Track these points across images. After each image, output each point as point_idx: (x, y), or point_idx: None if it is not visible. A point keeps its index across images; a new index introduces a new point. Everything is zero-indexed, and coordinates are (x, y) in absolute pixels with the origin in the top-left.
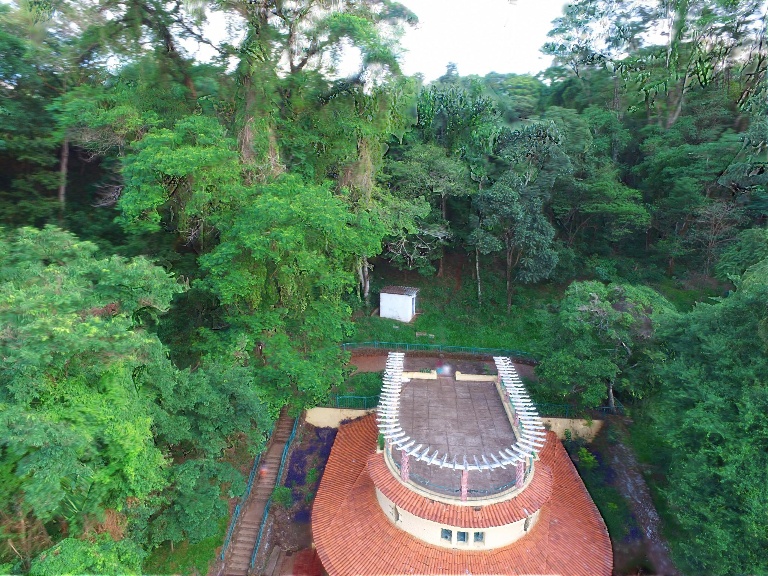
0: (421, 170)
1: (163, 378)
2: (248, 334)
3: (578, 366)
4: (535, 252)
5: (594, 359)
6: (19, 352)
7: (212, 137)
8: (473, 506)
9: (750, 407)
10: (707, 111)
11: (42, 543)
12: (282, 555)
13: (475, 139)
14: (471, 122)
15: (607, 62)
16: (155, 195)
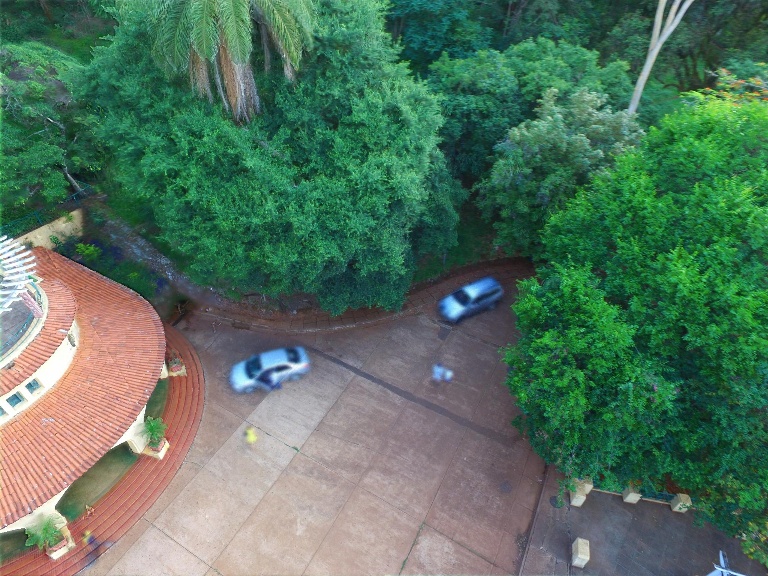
0: None
1: None
2: None
3: (16, 164)
4: None
5: (29, 149)
6: None
7: None
8: (4, 367)
9: (181, 135)
10: None
11: None
12: None
13: None
14: None
15: None
16: None
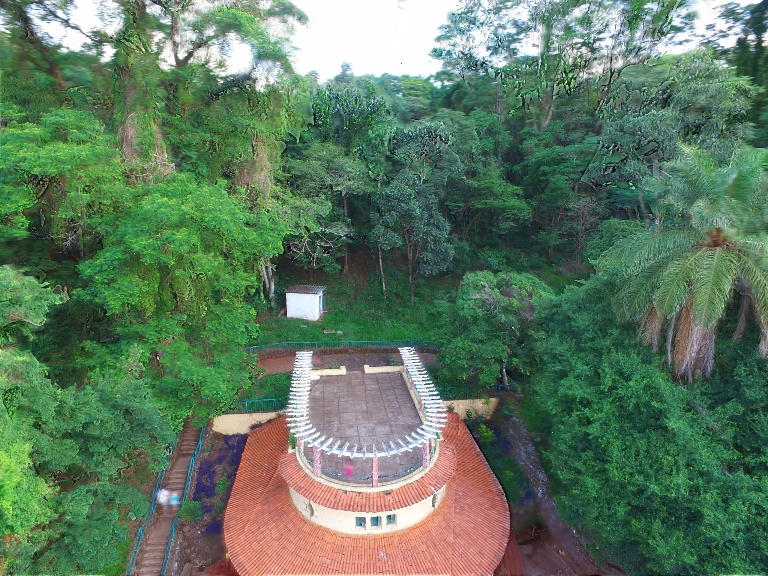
0: (320, 169)
1: (42, 399)
2: (142, 344)
3: (474, 350)
4: (433, 246)
5: (488, 342)
6: None
7: (87, 133)
8: (384, 491)
9: (608, 372)
10: (573, 116)
11: None
12: (194, 572)
13: (371, 139)
14: (367, 122)
15: (489, 69)
16: (20, 197)
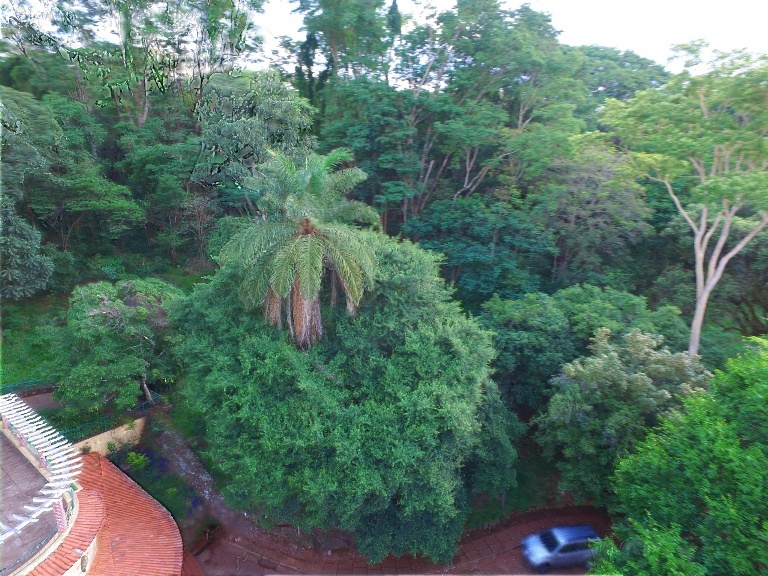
0: None
1: None
2: None
3: (104, 373)
4: (19, 261)
5: (119, 361)
6: None
7: None
8: None
9: (246, 356)
10: (171, 115)
11: None
12: None
13: None
14: None
15: (59, 47)
16: None
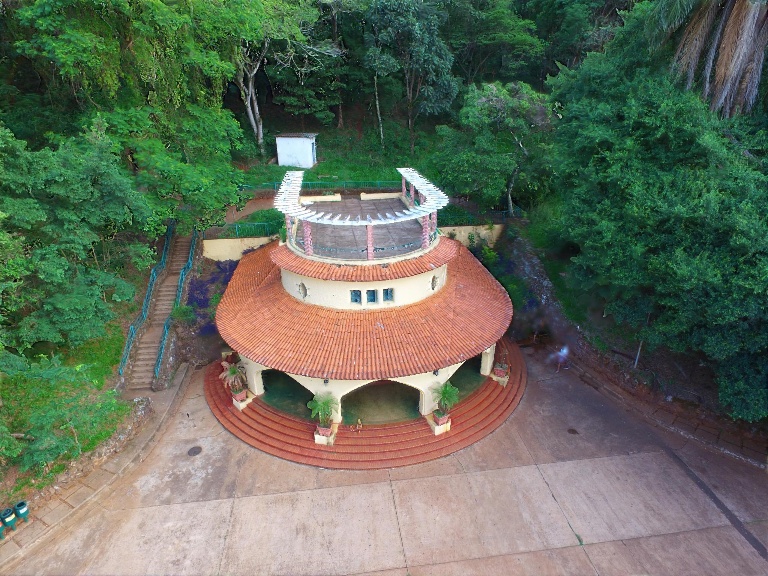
0: None
1: None
2: (111, 135)
3: (479, 161)
4: (435, 78)
5: (494, 156)
6: None
7: None
8: (380, 264)
9: (635, 104)
10: None
11: None
12: (191, 369)
13: None
14: None
15: None
16: None
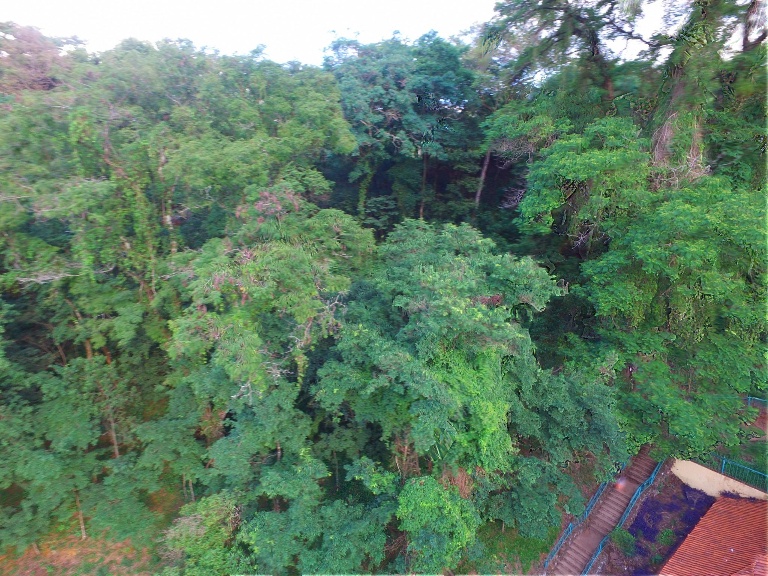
0: None
1: (526, 372)
2: (620, 352)
3: None
4: None
5: None
6: (427, 320)
7: (622, 139)
8: None
9: None
10: None
11: (414, 470)
12: None
13: None
14: None
15: None
16: (552, 199)
